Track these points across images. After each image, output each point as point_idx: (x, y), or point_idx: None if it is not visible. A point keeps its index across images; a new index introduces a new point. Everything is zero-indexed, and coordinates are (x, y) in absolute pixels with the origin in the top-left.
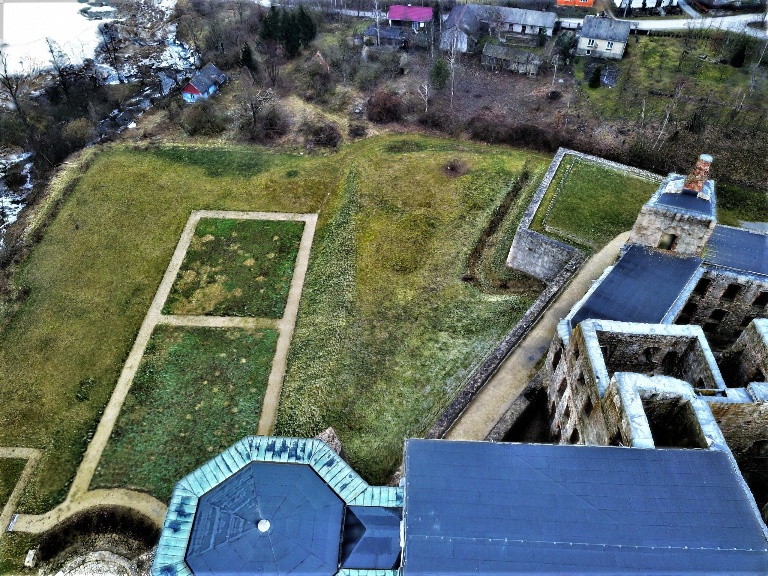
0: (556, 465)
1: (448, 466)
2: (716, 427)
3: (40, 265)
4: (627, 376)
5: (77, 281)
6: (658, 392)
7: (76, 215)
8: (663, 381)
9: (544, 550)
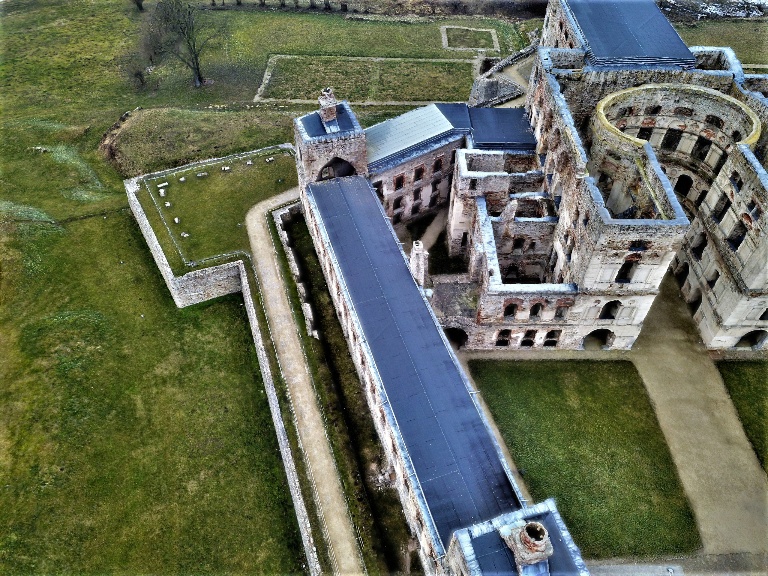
0: (658, 20)
1: (641, 0)
2: (715, 73)
3: (716, 26)
4: (729, 49)
5: (714, 39)
6: (726, 59)
7: (766, 28)
8: (735, 60)
9: (617, 13)
